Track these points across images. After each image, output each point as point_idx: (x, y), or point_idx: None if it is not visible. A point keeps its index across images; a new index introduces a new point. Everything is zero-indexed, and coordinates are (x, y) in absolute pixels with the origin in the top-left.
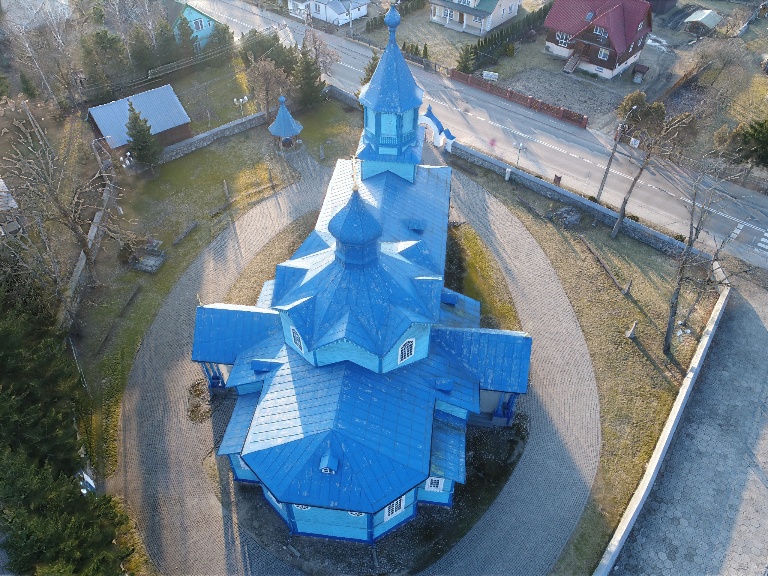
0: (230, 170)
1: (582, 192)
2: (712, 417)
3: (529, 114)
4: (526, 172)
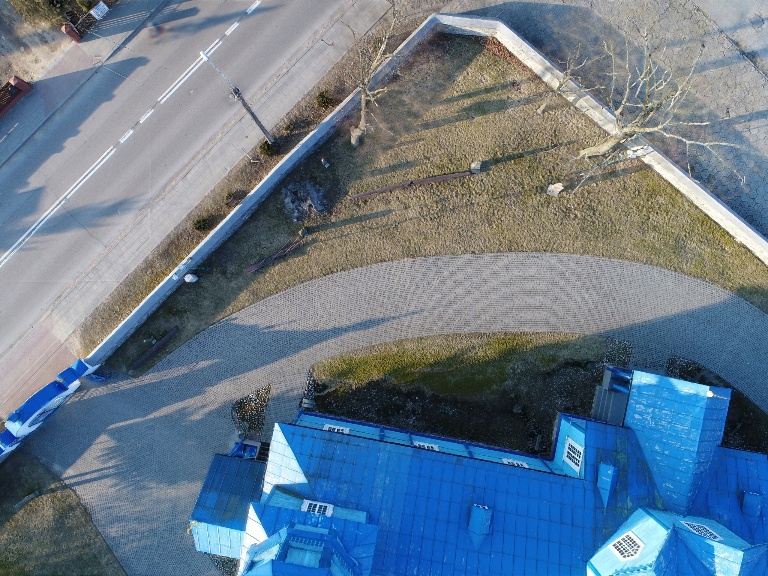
0: None
1: (243, 158)
2: None
3: None
4: (177, 240)
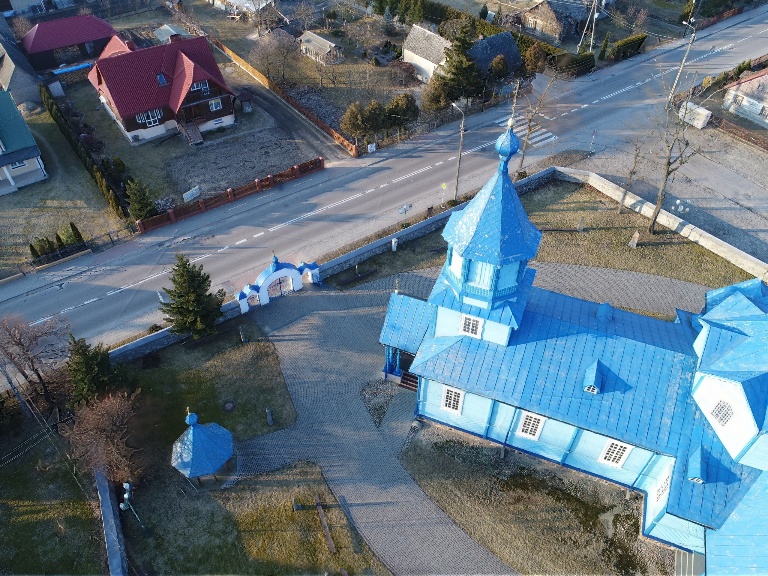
0: (243, 575)
1: (437, 206)
2: (718, 235)
3: (274, 195)
4: (388, 232)
